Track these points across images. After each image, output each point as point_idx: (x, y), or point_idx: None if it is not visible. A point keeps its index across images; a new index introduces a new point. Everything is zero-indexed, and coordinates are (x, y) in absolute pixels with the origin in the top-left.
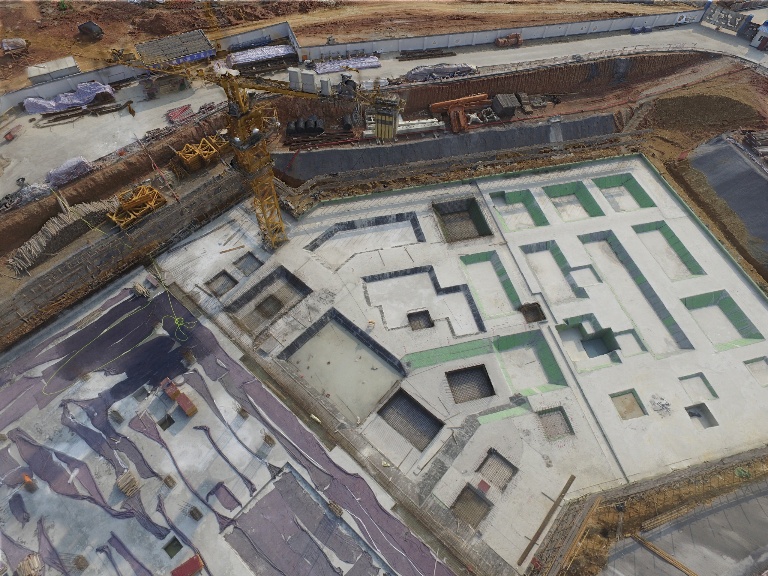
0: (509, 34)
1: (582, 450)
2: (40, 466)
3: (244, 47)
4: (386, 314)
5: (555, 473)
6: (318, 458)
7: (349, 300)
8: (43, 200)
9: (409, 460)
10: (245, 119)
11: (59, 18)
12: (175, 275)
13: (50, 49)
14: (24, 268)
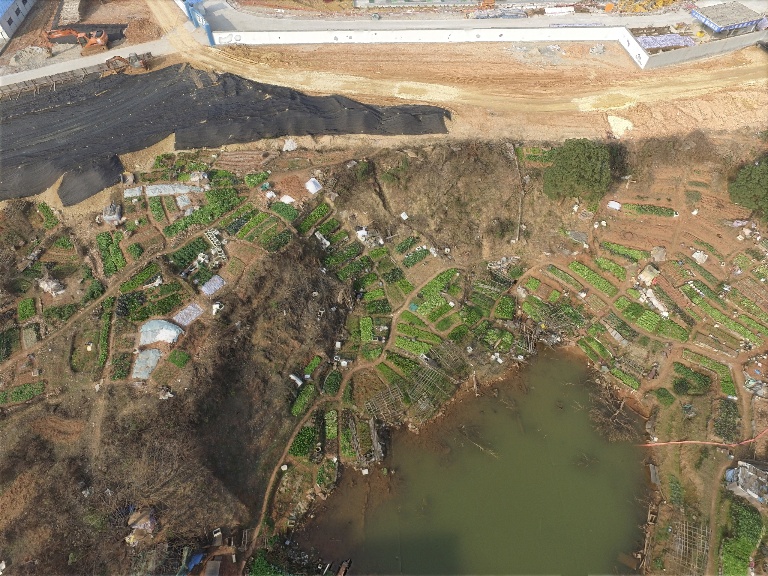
0: (428, 34)
1: None
2: None
3: None
4: None
5: None
6: None
7: None
8: None
9: None
10: None
11: None
12: None
13: None
14: None
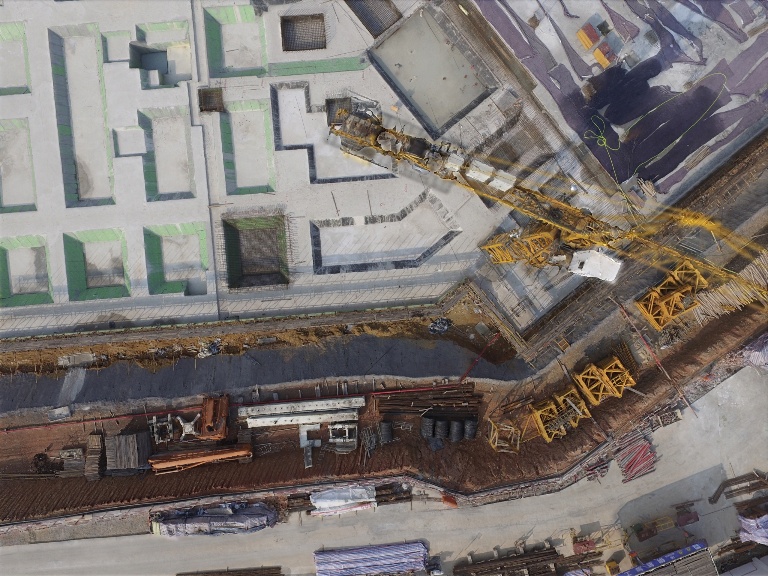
0: None
1: None
2: (712, 3)
3: None
4: None
5: None
6: None
7: None
8: None
9: None
10: None
11: None
12: (611, 208)
13: None
14: None
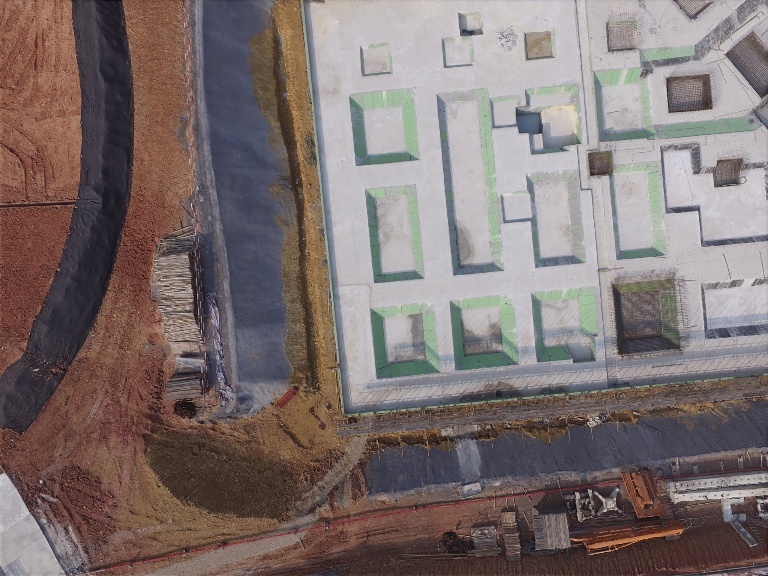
0: None
1: (605, 7)
2: None
3: None
4: (763, 188)
5: None
6: None
7: None
8: None
9: (766, 26)
10: None
11: None
12: None
13: None
14: None
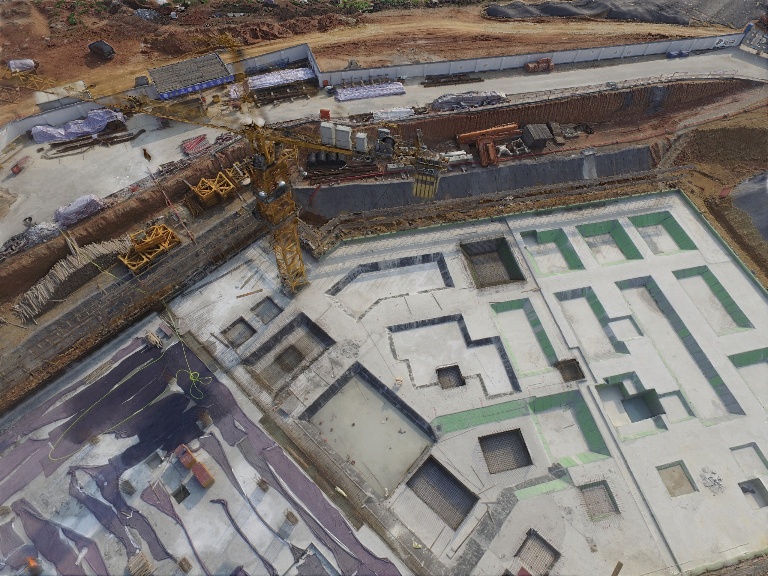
0: (539, 58)
1: (629, 532)
2: (46, 544)
3: (261, 70)
4: (414, 369)
5: (601, 559)
6: (344, 539)
7: (374, 353)
8: (51, 241)
9: (442, 540)
10: (270, 171)
11: (69, 35)
12: (190, 322)
13: (59, 70)
14: (30, 316)
